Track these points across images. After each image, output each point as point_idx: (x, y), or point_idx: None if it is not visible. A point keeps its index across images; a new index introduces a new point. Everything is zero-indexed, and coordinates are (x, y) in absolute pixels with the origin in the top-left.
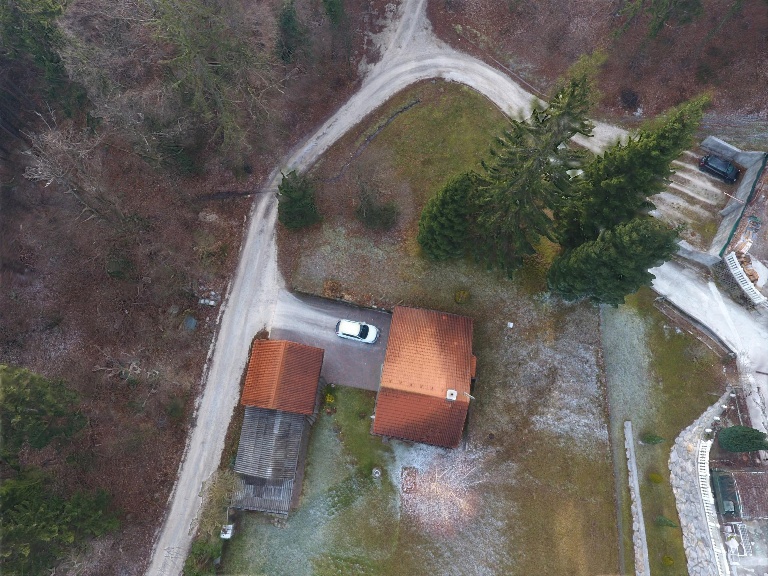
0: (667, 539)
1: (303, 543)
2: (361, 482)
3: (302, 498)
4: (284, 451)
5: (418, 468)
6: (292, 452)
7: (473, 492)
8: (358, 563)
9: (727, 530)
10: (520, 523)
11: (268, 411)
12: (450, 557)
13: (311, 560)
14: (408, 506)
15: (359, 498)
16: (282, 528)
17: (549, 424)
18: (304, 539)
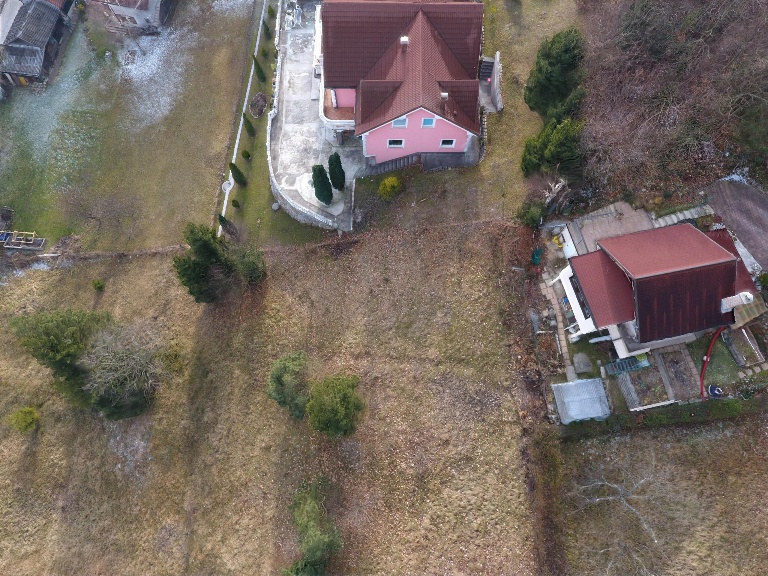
0: (271, 47)
1: (53, 105)
2: (97, 62)
3: (57, 77)
4: (36, 27)
5: (137, 50)
6: (43, 32)
7: (168, 56)
8: (89, 113)
9: (288, 11)
10: (193, 67)
11: (29, 4)
12: (146, 97)
13: (57, 114)
14: (127, 73)
15: (95, 73)
16: (40, 96)
17: (222, 4)
18: (54, 102)
